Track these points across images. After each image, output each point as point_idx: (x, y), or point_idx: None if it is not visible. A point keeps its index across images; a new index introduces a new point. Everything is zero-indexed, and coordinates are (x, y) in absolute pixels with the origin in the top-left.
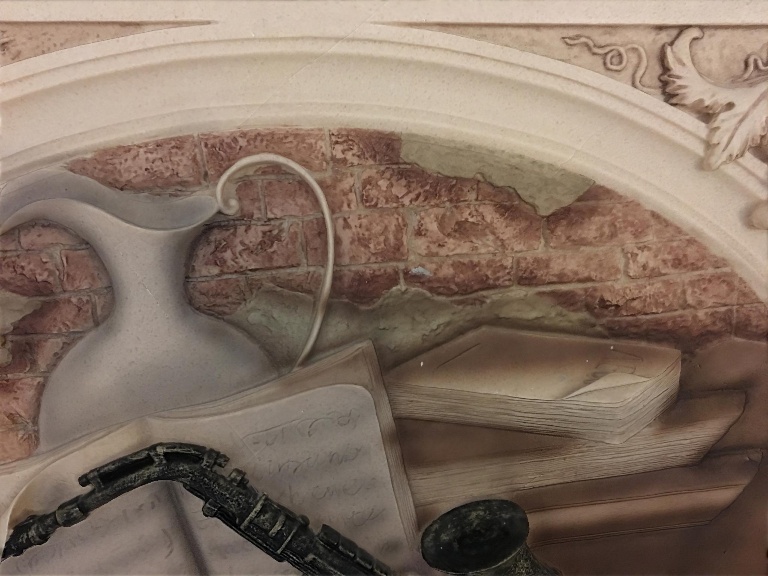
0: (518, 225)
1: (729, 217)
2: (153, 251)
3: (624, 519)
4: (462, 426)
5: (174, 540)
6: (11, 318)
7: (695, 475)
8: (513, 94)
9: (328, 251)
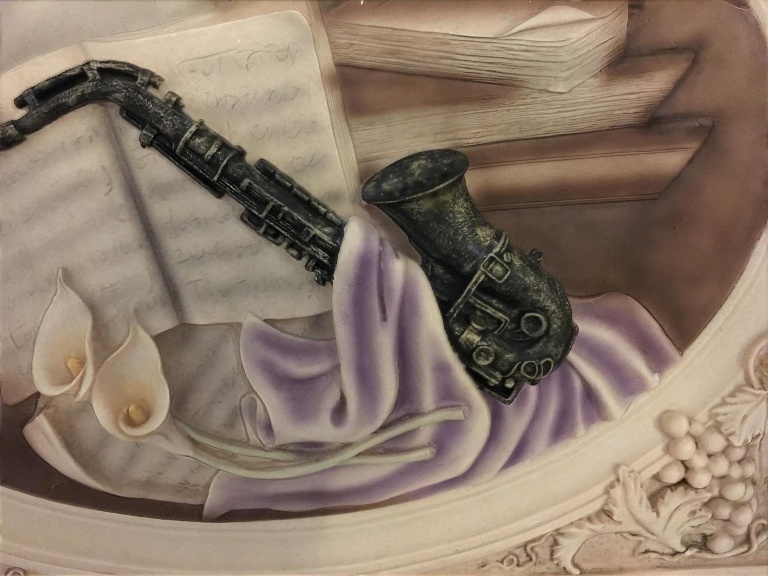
0: None
1: None
2: None
3: (570, 183)
4: (404, 75)
5: (113, 179)
6: None
7: (643, 136)
8: None
9: None
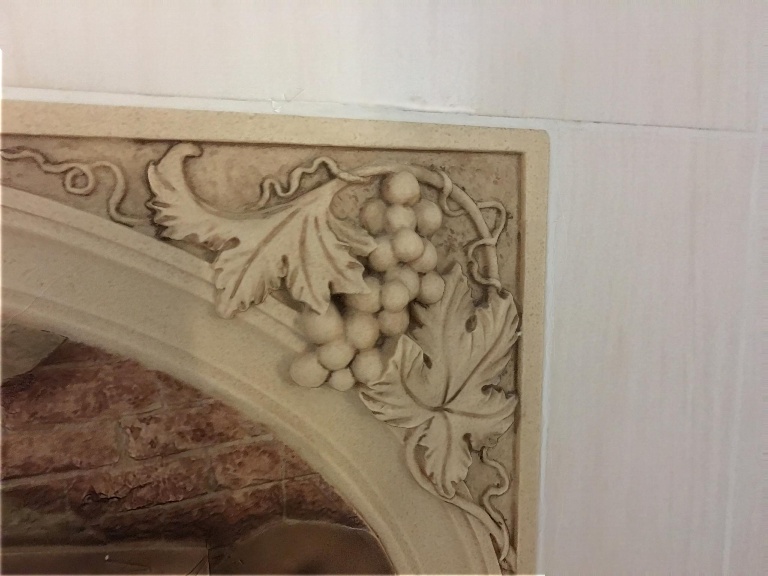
0: None
1: (264, 372)
2: None
3: None
4: None
5: None
6: None
7: None
8: None
9: None
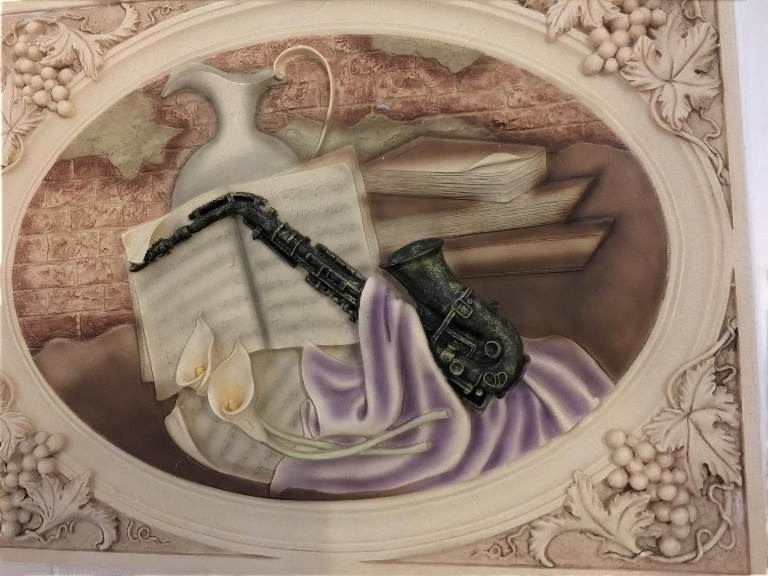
0: (439, 80)
1: (572, 70)
2: (239, 95)
3: (517, 259)
4: (409, 197)
5: (236, 259)
6: (167, 138)
7: (564, 229)
8: (434, 11)
9: (330, 94)
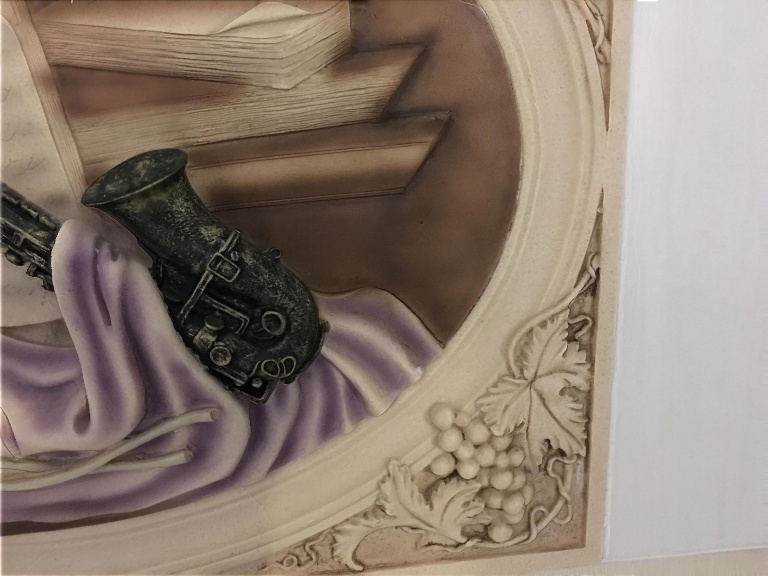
0: None
1: None
2: None
3: (308, 180)
4: (126, 74)
5: None
6: None
7: (376, 131)
8: None
9: None
